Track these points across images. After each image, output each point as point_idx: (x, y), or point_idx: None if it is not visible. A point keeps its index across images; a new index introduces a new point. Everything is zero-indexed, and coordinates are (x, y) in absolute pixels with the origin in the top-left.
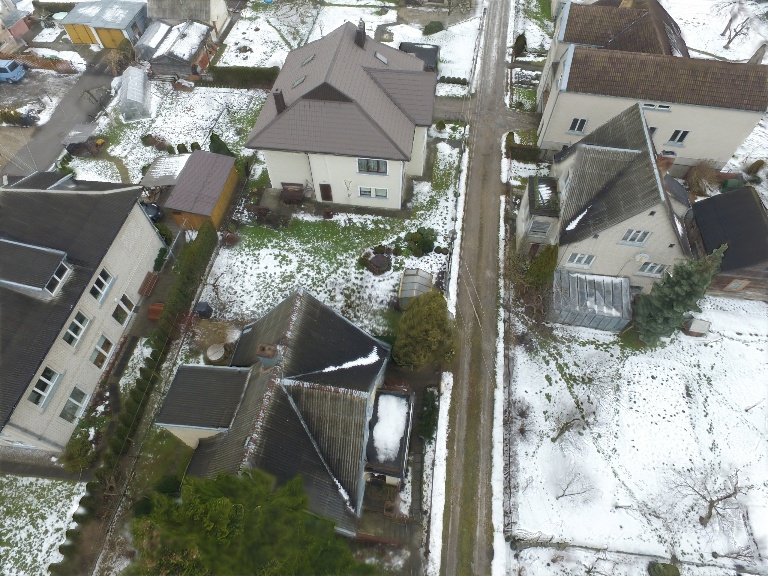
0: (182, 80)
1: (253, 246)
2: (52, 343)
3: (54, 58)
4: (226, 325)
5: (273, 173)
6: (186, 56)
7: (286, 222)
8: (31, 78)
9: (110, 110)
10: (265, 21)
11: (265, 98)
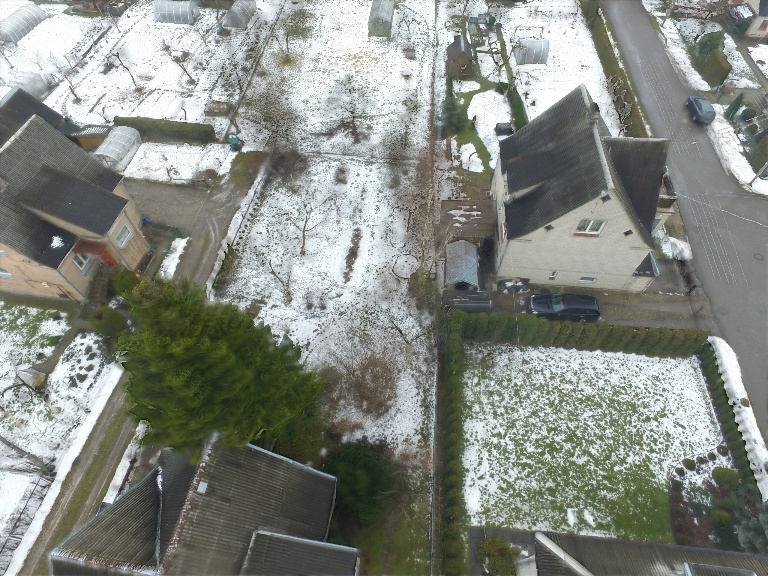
0: None
1: None
2: None
3: None
4: None
5: None
6: None
7: None
8: None
9: None
10: None
11: None
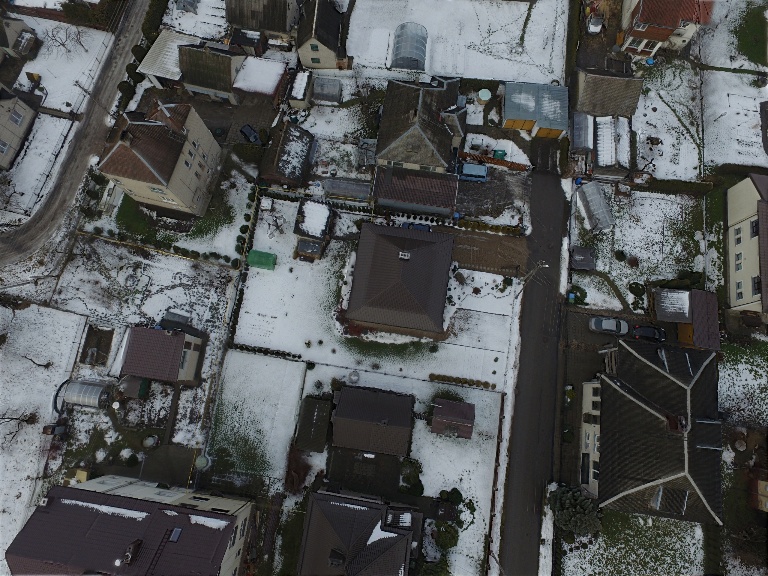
0: (621, 185)
1: (732, 362)
2: (720, 473)
3: (516, 162)
4: (736, 424)
5: (745, 307)
6: (627, 164)
7: (749, 342)
8: (491, 176)
9: (574, 218)
10: (657, 95)
11: (692, 206)
